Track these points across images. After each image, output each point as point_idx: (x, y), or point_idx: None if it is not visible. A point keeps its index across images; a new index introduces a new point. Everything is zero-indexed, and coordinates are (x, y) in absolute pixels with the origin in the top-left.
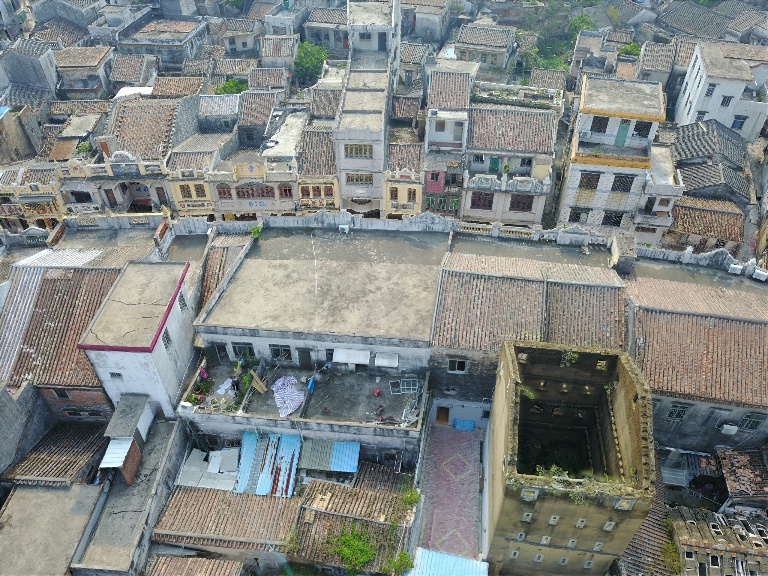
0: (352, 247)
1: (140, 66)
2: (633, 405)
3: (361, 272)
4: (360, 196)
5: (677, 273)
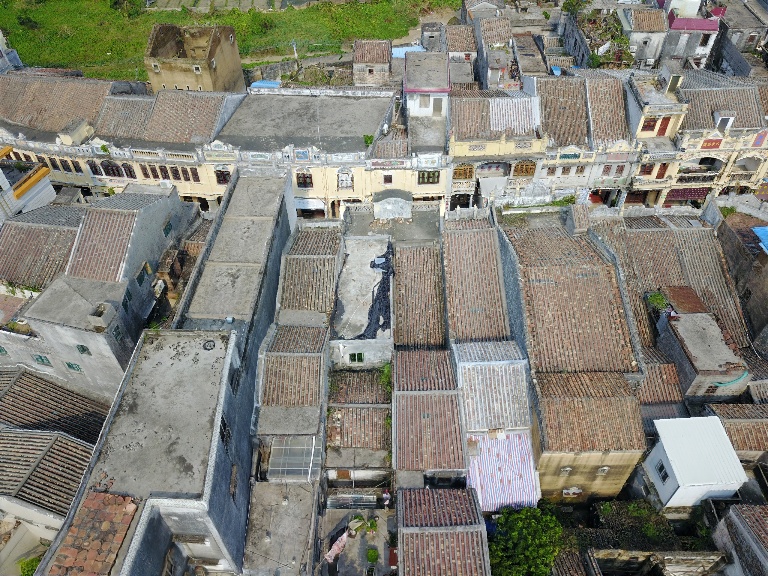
0: None
1: (761, 538)
2: None
3: (284, 129)
4: None
5: (43, 139)
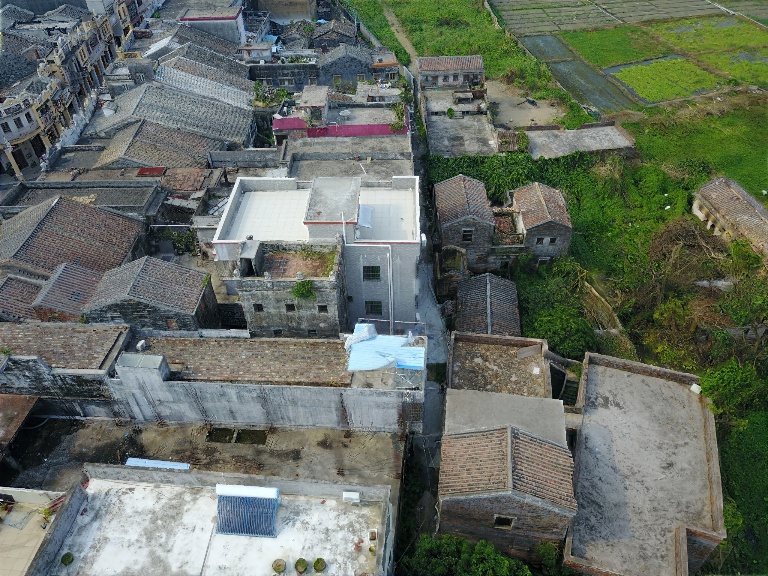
0: None
1: None
2: None
3: None
4: (115, 23)
5: None
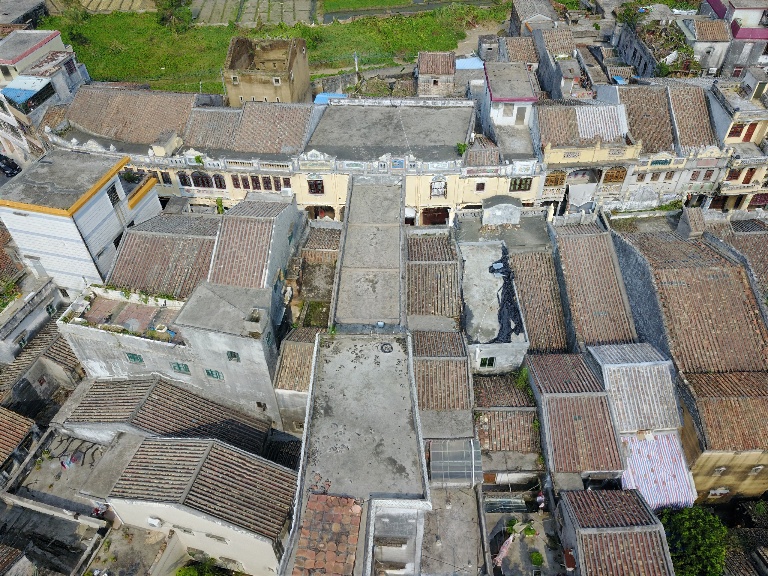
0: (380, 156)
1: None
2: (238, 48)
3: (372, 139)
4: None
5: (131, 151)
